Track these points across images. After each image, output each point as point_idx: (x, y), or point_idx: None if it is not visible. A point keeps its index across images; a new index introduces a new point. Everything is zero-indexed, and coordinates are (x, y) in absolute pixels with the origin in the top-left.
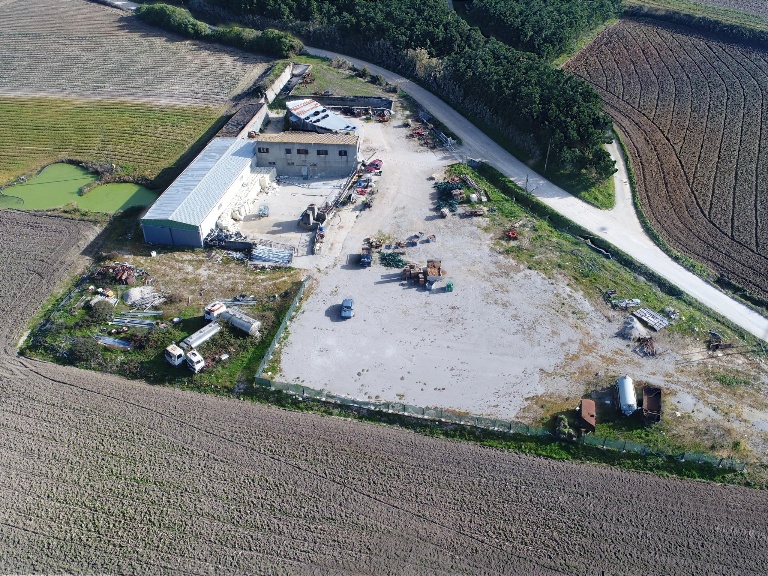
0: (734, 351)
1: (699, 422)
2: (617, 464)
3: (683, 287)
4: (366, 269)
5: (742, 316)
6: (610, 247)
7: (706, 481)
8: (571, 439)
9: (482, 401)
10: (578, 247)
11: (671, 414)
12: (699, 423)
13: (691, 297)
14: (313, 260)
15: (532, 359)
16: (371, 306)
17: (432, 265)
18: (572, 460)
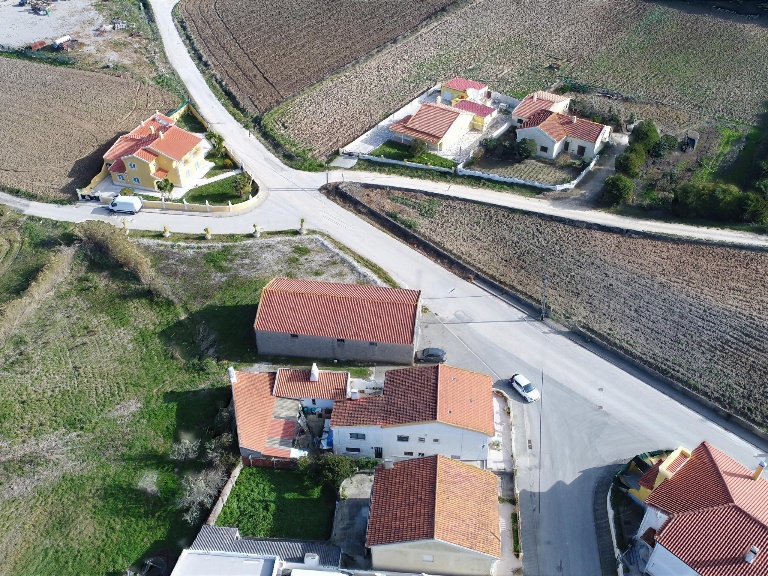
0: (139, 37)
1: (84, 53)
2: (33, 61)
3: (158, 20)
4: (22, 7)
5: (168, 30)
6: (148, 6)
7: (59, 66)
8: (22, 52)
9: (7, 43)
10: (133, 5)
11: (77, 50)
12: (84, 53)
13: (155, 23)
14: (2, 3)
15: (48, 34)
16: (5, 17)
17: (48, 4)
18: (17, 59)
